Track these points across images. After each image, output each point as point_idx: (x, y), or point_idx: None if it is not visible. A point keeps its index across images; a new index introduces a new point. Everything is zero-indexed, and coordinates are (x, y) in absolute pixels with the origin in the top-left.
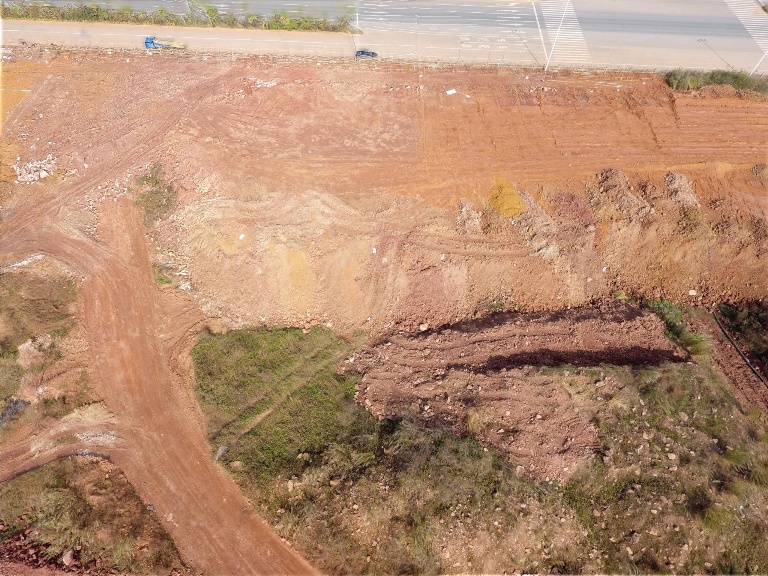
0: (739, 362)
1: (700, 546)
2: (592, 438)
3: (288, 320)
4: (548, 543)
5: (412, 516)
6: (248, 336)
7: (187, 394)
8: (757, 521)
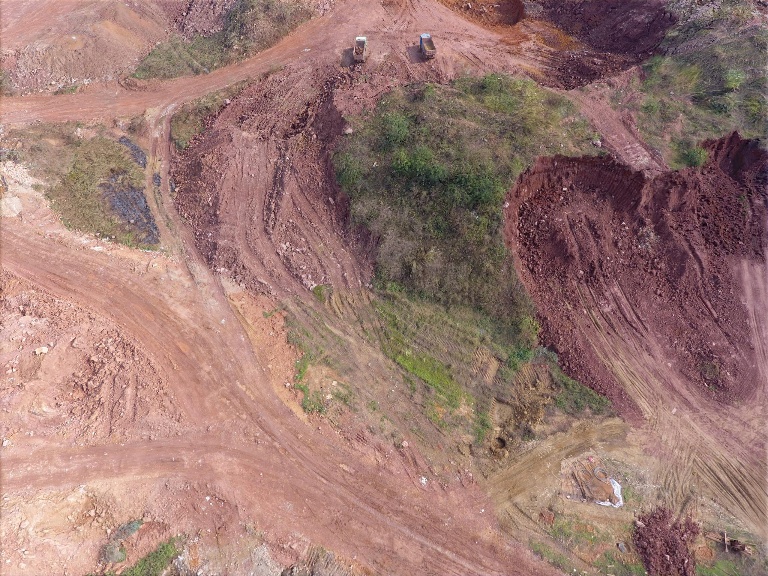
0: None
1: None
2: None
3: None
4: None
5: (265, 5)
6: (144, 65)
7: (165, 83)
8: None
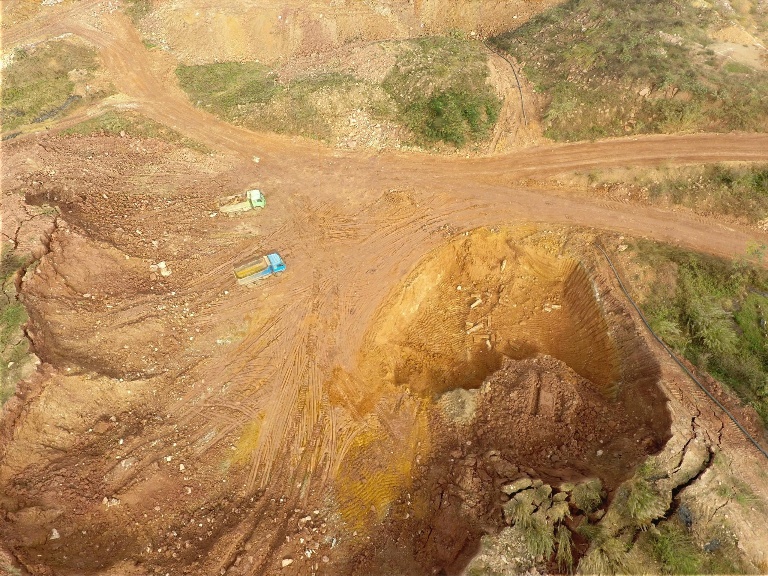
0: (489, 51)
1: (439, 85)
2: (394, 62)
3: (232, 59)
4: (370, 100)
5: (301, 94)
6: (208, 66)
7: (175, 88)
8: (465, 72)
